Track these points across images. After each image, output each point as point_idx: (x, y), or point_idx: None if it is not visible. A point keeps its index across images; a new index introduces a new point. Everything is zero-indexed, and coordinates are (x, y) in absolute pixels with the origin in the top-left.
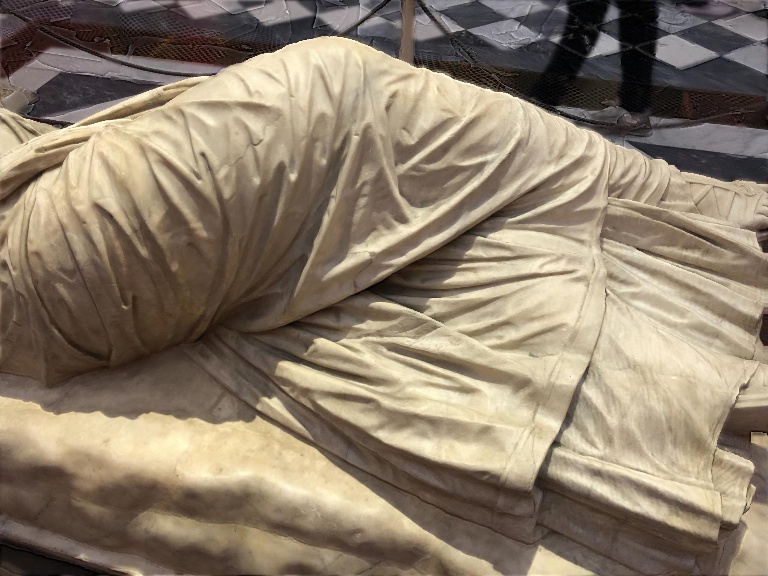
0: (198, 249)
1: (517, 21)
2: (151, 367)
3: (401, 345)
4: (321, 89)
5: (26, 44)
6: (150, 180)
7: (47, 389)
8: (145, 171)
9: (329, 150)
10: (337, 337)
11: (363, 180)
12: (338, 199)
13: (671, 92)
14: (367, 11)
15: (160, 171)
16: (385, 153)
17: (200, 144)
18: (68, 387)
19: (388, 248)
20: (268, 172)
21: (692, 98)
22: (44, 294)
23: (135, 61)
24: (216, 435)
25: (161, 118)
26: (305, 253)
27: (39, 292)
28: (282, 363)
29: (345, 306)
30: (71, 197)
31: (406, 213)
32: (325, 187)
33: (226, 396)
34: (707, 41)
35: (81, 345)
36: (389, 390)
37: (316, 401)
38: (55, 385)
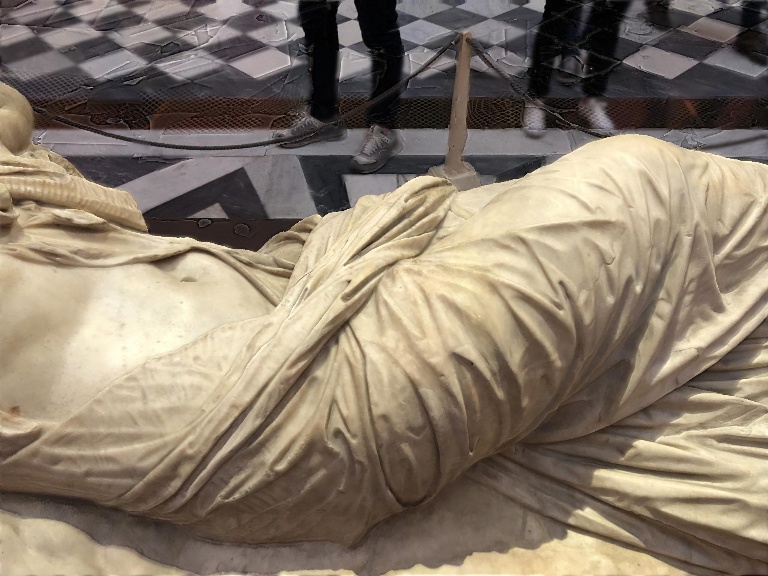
0: (549, 379)
1: (500, 47)
2: (442, 500)
3: (737, 436)
4: (651, 194)
5: (38, 136)
6: (508, 318)
7: (351, 550)
8: (500, 309)
9: (664, 255)
10: (653, 436)
11: (690, 278)
12: (675, 302)
13: (674, 102)
14: (419, 64)
15: (518, 307)
16: (709, 248)
17: (556, 272)
18: (372, 543)
19: (715, 341)
20: (619, 289)
21: (695, 106)
22: (386, 457)
23: (165, 140)
24: (542, 562)
25: (494, 248)
26: (626, 359)
27: (381, 456)
28: (598, 472)
29: (657, 403)
30: (421, 350)
31: (723, 302)
32: (653, 291)
33: (529, 515)
34: (681, 48)
35: (402, 499)
36: (740, 485)
37: (660, 509)
38: (358, 544)
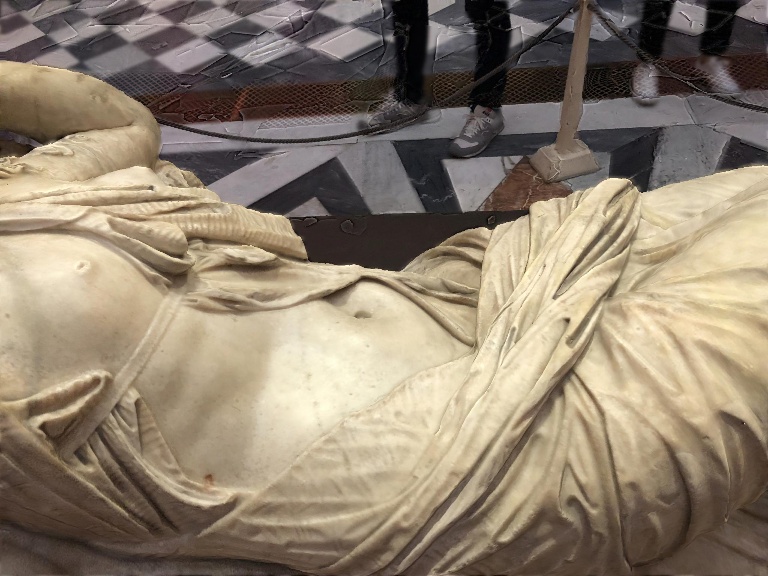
0: None
1: None
2: None
3: None
4: None
5: None
6: None
7: None
8: None
9: None
10: None
11: None
12: None
13: None
14: (533, 37)
15: None
16: None
17: None
18: None
19: None
20: None
21: None
22: (628, 527)
23: (261, 135)
24: None
25: (758, 280)
26: None
27: (623, 526)
28: None
29: None
30: (679, 407)
31: None
32: None
33: (760, 571)
34: None
35: None
36: None
37: None
38: None
